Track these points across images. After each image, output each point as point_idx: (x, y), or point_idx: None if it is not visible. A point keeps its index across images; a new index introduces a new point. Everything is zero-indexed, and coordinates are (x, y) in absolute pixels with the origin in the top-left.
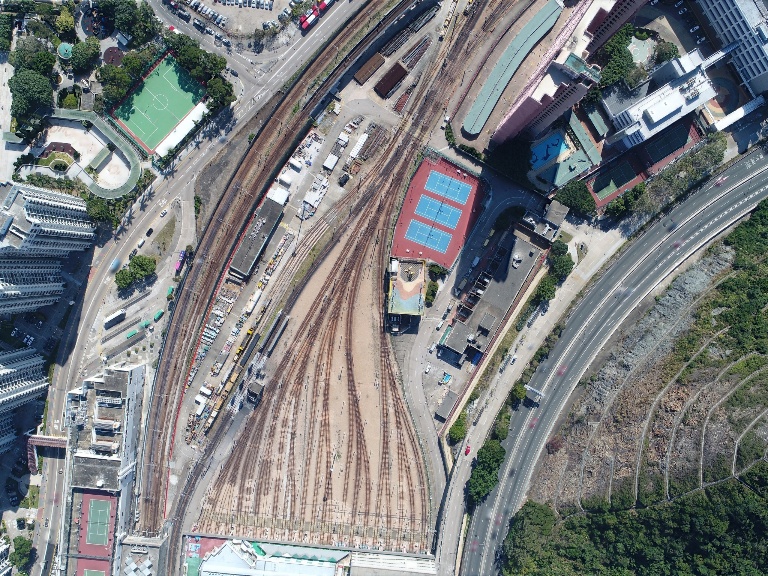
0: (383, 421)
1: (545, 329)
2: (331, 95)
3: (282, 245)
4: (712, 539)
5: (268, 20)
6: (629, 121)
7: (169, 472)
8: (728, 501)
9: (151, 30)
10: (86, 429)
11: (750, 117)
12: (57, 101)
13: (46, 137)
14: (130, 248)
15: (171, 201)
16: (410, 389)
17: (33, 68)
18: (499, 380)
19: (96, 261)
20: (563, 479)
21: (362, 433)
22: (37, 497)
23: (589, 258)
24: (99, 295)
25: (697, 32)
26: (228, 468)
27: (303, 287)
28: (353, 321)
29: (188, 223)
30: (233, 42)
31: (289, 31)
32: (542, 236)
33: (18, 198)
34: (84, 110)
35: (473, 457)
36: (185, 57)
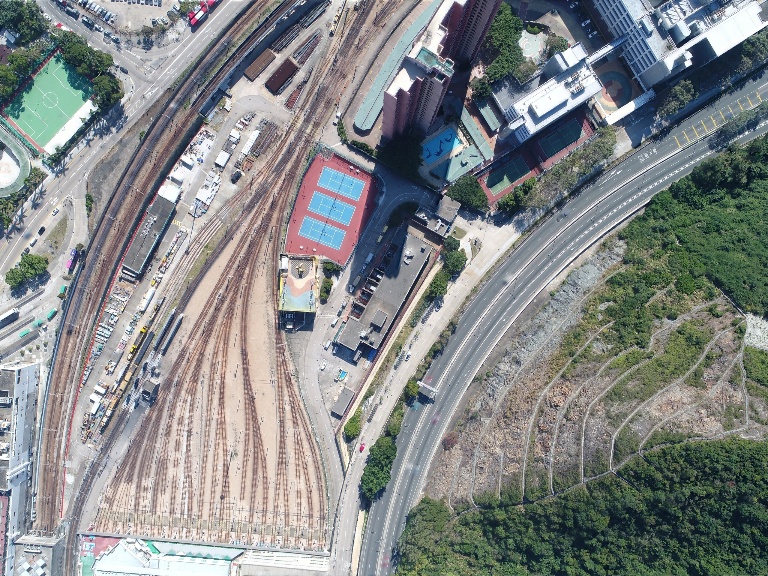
0: (279, 418)
1: (440, 325)
2: (222, 92)
3: (175, 243)
4: (596, 534)
5: (157, 17)
6: (516, 116)
7: (65, 471)
8: (607, 496)
9: (37, 27)
10: None
11: (643, 111)
12: None
13: None
14: (22, 247)
15: (63, 199)
16: (306, 386)
17: None
18: (393, 377)
19: None
20: (457, 475)
21: (258, 431)
22: None
23: (483, 254)
24: None
25: (589, 26)
26: (124, 467)
27: (197, 285)
28: (248, 318)
29: (80, 221)
30: (122, 39)
31: (178, 27)
32: (435, 232)
33: None
34: None
35: (368, 454)
36: (70, 54)
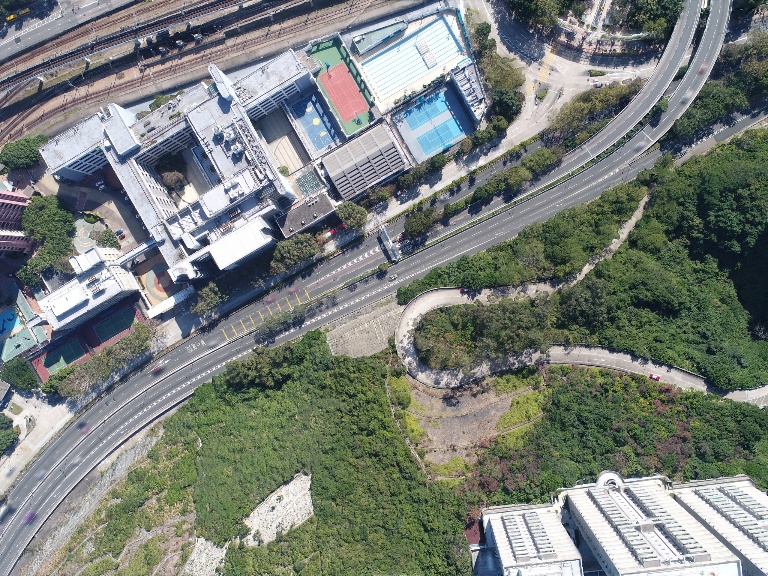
0: None
1: None
2: None
3: None
4: None
5: None
6: None
7: None
8: None
9: None
10: None
11: None
12: None
13: None
14: None
15: None
16: None
17: None
18: None
19: None
20: None
21: None
22: None
23: (37, 431)
24: None
25: None
26: None
27: None
28: None
29: None
30: None
31: None
32: None
33: None
34: None
35: None
36: None
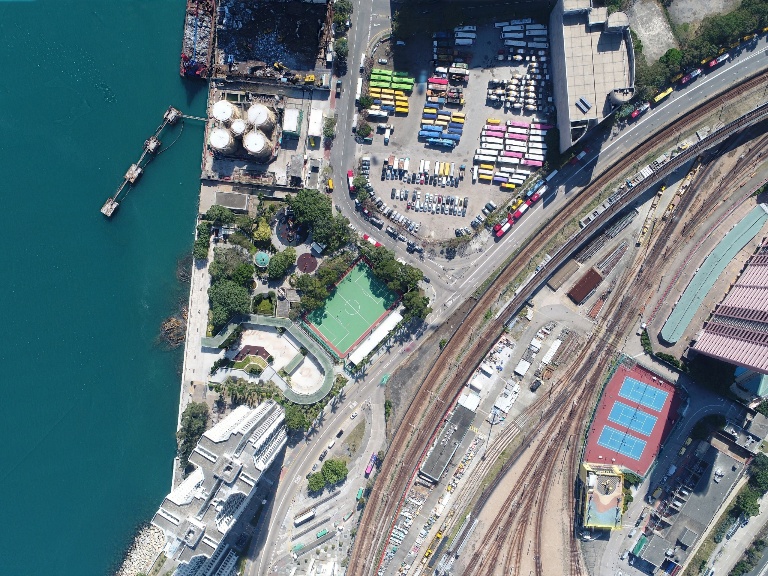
0: None
1: (745, 541)
2: None
3: (472, 449)
4: None
5: (461, 227)
6: None
7: None
8: None
9: (347, 241)
10: None
11: None
12: (252, 306)
13: (240, 340)
14: (320, 449)
15: (361, 404)
16: None
17: (233, 279)
18: None
19: (287, 461)
20: None
21: None
22: None
23: None
24: (289, 493)
25: None
26: None
27: (492, 491)
28: (542, 526)
29: (378, 425)
30: (425, 249)
31: (482, 238)
32: (744, 448)
33: (248, 446)
34: (279, 317)
35: None
36: (383, 272)
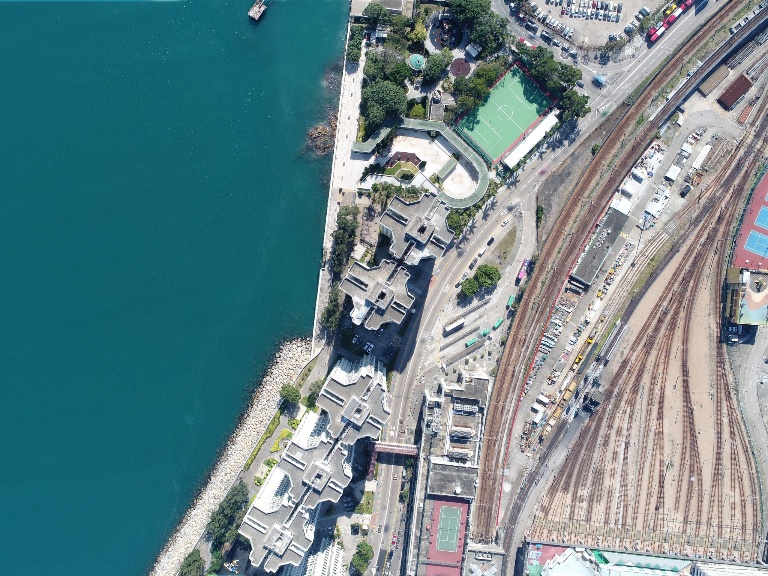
0: (717, 431)
1: None
2: None
3: (622, 255)
4: None
5: (614, 32)
6: None
7: (503, 479)
8: None
9: (505, 42)
10: (439, 436)
11: None
12: None
13: (391, 147)
14: (470, 257)
15: (512, 211)
16: (745, 399)
17: (390, 79)
18: None
19: (437, 270)
20: None
21: (696, 443)
22: (371, 503)
23: None
24: (438, 303)
25: None
26: (561, 476)
27: (641, 297)
28: (690, 331)
29: (529, 232)
30: (579, 54)
31: (635, 43)
32: None
33: (440, 208)
34: (434, 120)
35: None
36: (545, 69)
